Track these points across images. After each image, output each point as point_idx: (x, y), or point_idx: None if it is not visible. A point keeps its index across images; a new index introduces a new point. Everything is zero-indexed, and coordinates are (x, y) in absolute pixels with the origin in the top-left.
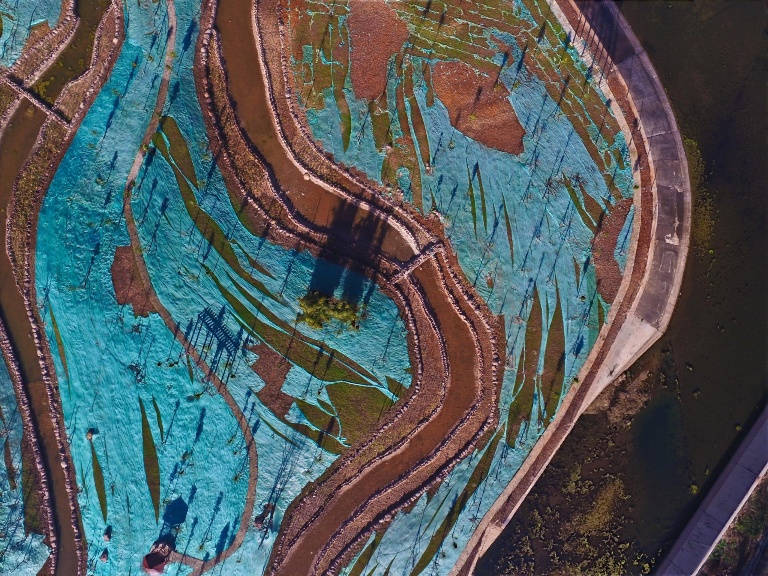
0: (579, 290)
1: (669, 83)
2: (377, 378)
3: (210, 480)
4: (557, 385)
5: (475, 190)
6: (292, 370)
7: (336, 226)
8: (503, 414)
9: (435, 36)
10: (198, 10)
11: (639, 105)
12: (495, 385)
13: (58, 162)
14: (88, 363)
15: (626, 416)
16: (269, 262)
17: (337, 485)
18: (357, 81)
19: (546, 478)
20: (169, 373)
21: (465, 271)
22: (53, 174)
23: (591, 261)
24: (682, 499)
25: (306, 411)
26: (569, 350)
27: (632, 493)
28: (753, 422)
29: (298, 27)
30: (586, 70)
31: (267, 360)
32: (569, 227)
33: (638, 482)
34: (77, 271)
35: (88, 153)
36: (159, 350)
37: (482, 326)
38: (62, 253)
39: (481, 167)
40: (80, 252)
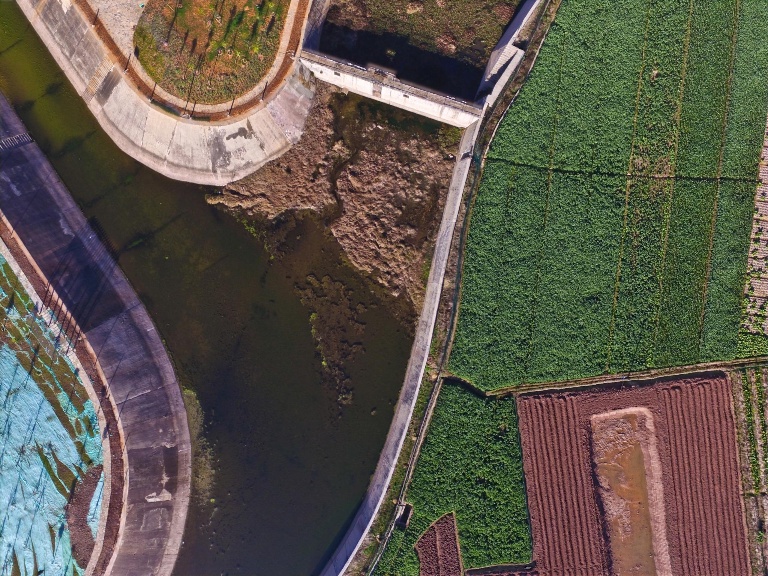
0: (55, 555)
1: (168, 334)
2: None
3: None
4: None
5: None
6: None
7: None
8: None
9: None
10: None
11: (111, 371)
12: None
13: None
14: None
15: None
16: None
17: None
18: None
19: None
20: None
21: None
22: None
23: (66, 527)
24: None
25: None
26: None
27: None
28: None
29: None
30: (54, 339)
31: None
32: (43, 494)
33: None
34: None
35: None
36: None
37: None
38: None
39: None
40: None
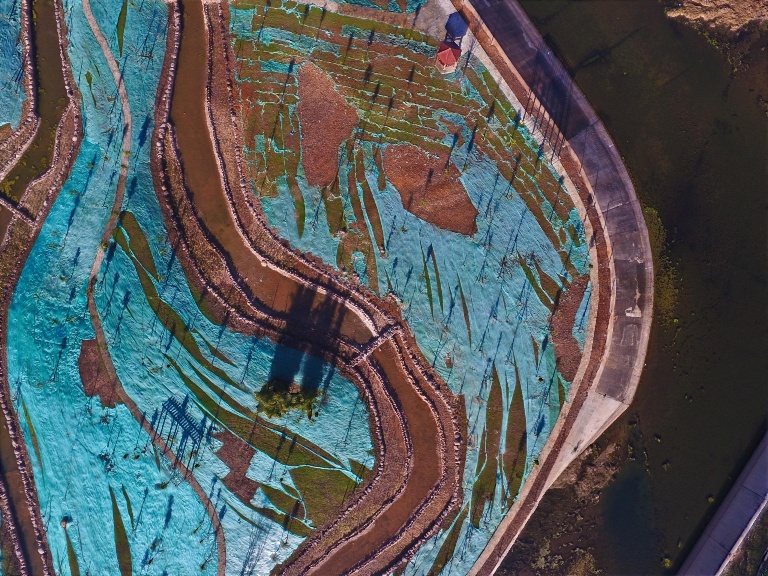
0: (538, 369)
1: (626, 151)
2: (340, 461)
3: (180, 565)
4: (519, 464)
5: (430, 272)
6: (256, 456)
7: (295, 311)
8: (467, 494)
9: (385, 120)
10: (152, 105)
11: (593, 180)
12: (458, 465)
13: (25, 259)
14: (60, 454)
15: (594, 490)
16: (230, 350)
17: (305, 566)
18: (309, 168)
19: (515, 553)
20: (137, 462)
21: (424, 352)
22: (21, 271)
23: (549, 339)
24: (655, 572)
25: (271, 496)
26: (530, 429)
27: (603, 567)
28: (726, 493)
29: (250, 117)
30: (537, 147)
31: (231, 447)
32: (526, 306)
33: (609, 556)
34: (46, 365)
35: (52, 250)
36: (126, 440)
37: (443, 405)
38: (31, 348)
39: (435, 249)
40: (48, 347)
